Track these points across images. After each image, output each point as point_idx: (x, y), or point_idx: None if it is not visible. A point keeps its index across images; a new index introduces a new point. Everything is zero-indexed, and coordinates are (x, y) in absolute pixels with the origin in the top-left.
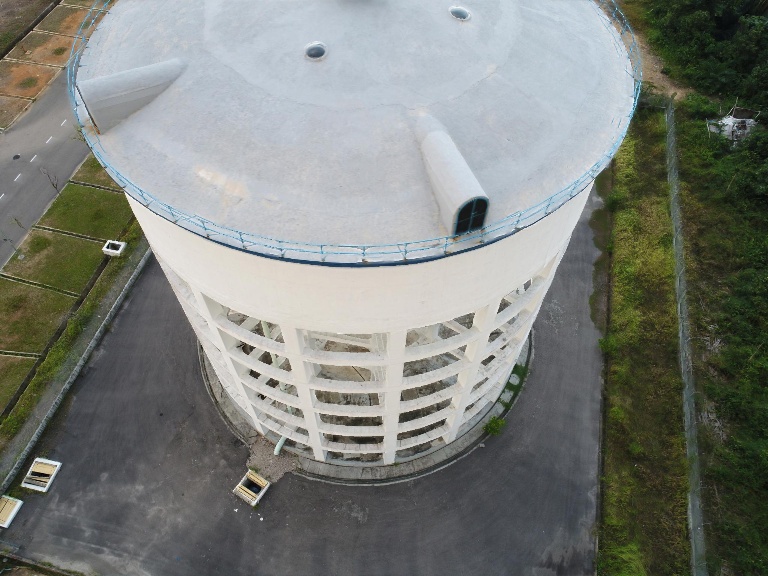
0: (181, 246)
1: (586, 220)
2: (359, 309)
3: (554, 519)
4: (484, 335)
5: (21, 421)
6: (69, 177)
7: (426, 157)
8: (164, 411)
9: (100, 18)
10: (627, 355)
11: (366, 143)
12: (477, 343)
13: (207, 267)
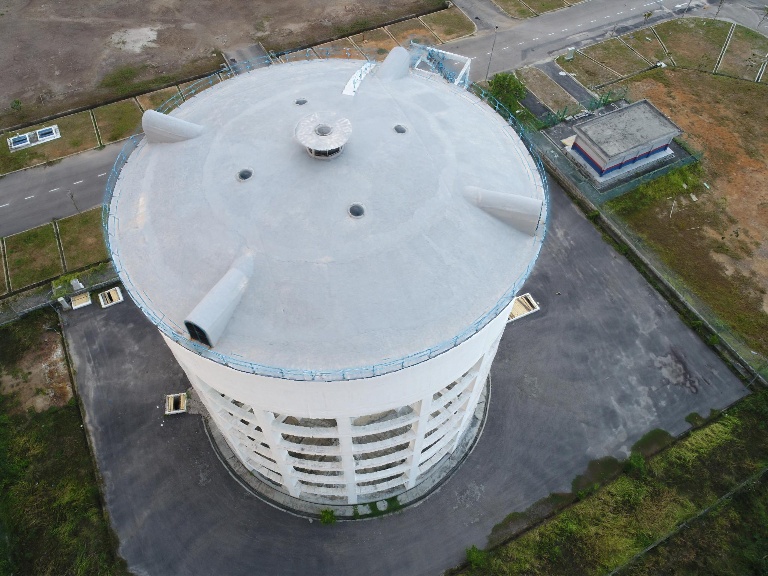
0: None
1: (592, 457)
2: None
3: None
4: None
5: None
6: None
7: None
8: None
9: (430, 42)
10: None
11: (206, 247)
12: None
13: None
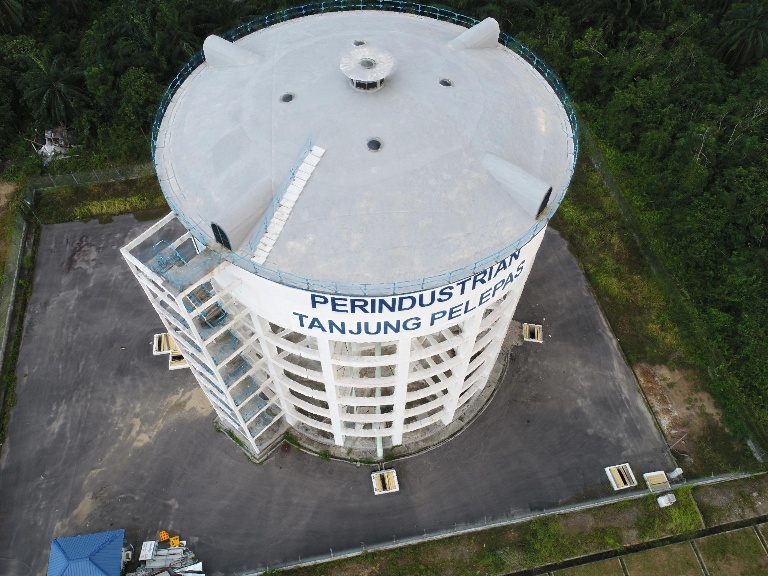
0: None
1: None
2: None
3: None
4: None
5: (603, 531)
6: None
7: None
8: (525, 421)
9: None
10: None
11: (483, 63)
12: None
13: None
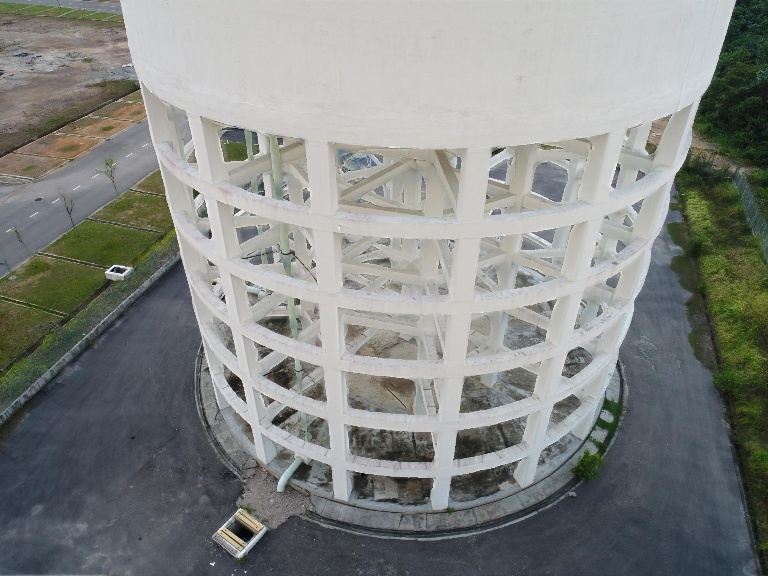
0: (181, 12)
1: (666, 265)
2: (425, 82)
3: None
4: (595, 217)
5: None
6: (88, 216)
7: None
8: (138, 434)
9: None
10: (754, 397)
11: None
12: (584, 233)
13: (212, 37)
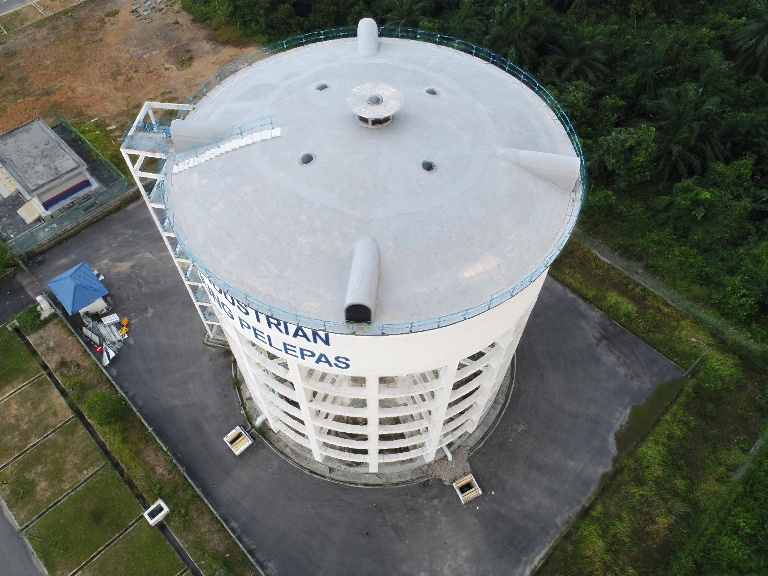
0: (463, 334)
1: None
2: None
3: (575, 322)
4: None
5: None
6: (14, 529)
7: (531, 167)
8: (365, 530)
9: None
10: None
11: (506, 185)
12: None
13: (480, 330)
